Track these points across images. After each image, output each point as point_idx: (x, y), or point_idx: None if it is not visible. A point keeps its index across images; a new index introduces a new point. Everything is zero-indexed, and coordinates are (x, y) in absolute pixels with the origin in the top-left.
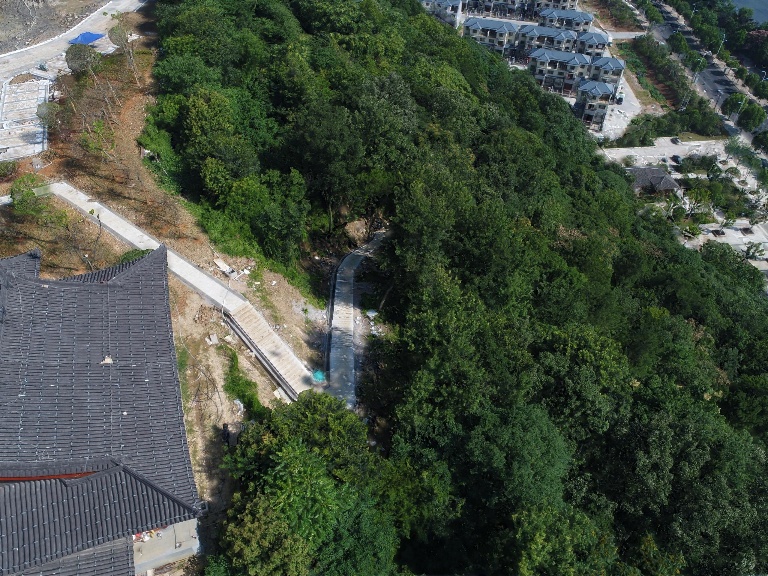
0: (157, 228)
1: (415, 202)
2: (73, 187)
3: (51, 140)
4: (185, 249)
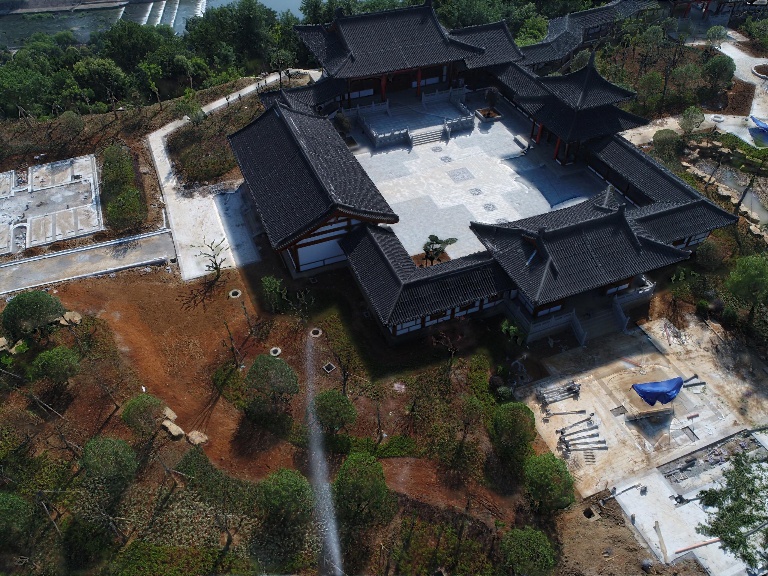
0: (222, 92)
1: (248, 3)
2: (159, 129)
3: (71, 157)
4: (243, 85)
